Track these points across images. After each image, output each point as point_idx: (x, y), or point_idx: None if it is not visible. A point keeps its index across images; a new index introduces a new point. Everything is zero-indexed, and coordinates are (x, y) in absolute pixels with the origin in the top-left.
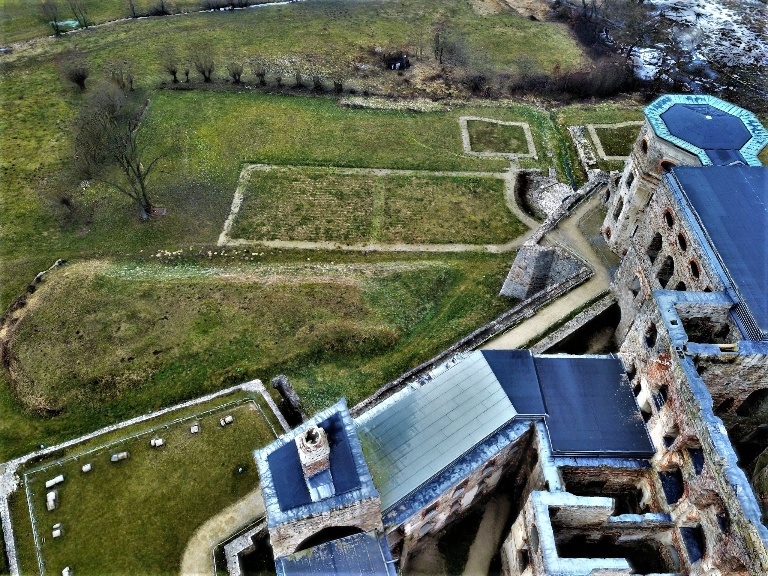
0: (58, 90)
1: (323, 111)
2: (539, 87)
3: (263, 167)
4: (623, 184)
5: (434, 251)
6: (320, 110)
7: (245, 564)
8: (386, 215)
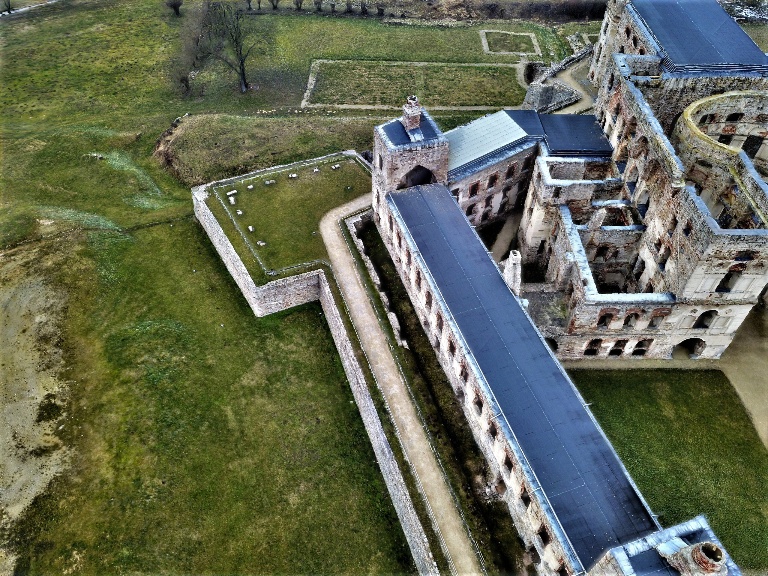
0: (158, 15)
1: (370, 26)
2: (543, 10)
3: (328, 61)
4: (602, 34)
5: (464, 110)
6: (368, 26)
7: (357, 231)
8: (426, 89)
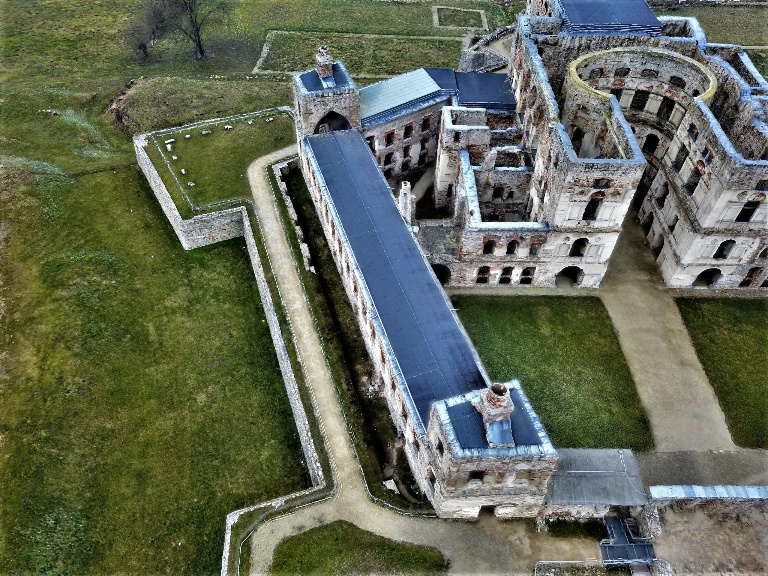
0: None
1: (328, 1)
2: None
3: (283, 32)
4: (528, 3)
5: None
6: (325, 0)
7: (284, 177)
8: (373, 59)
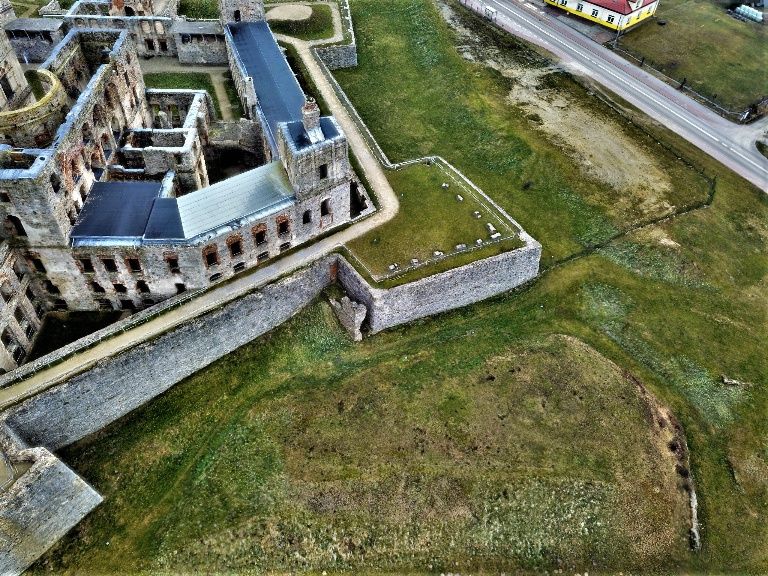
0: None
1: None
2: None
3: None
4: None
5: None
6: None
7: None
8: None
